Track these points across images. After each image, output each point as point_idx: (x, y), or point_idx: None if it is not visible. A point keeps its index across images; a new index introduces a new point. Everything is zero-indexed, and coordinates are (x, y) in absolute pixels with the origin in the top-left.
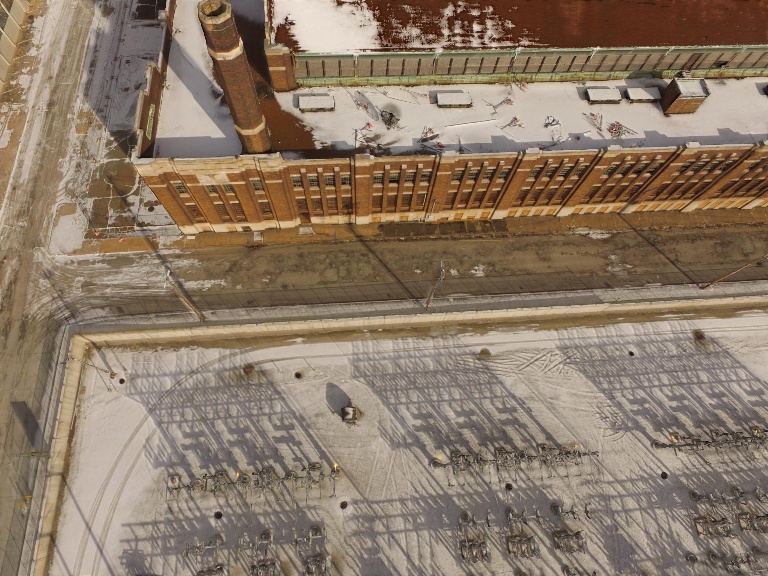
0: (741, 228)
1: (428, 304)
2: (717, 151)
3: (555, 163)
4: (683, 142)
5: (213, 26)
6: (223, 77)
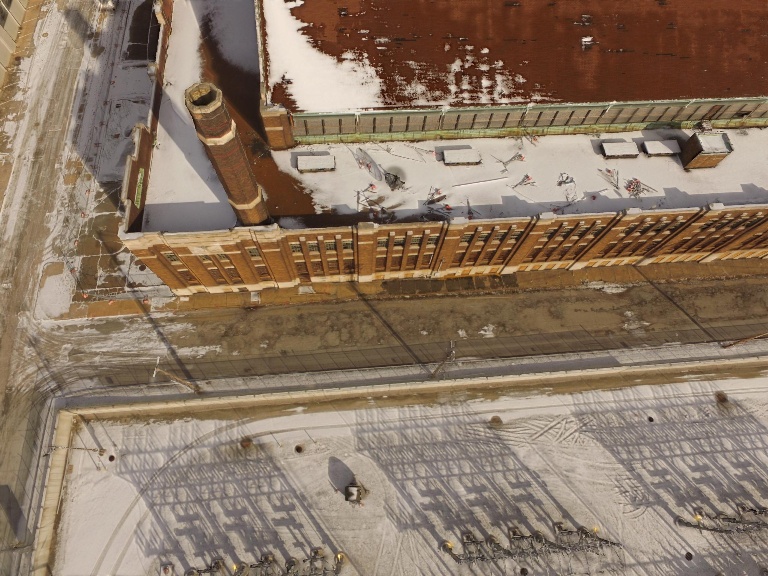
0: (763, 279)
1: (436, 372)
2: (742, 211)
3: (570, 225)
4: (705, 200)
5: (202, 115)
6: (214, 159)
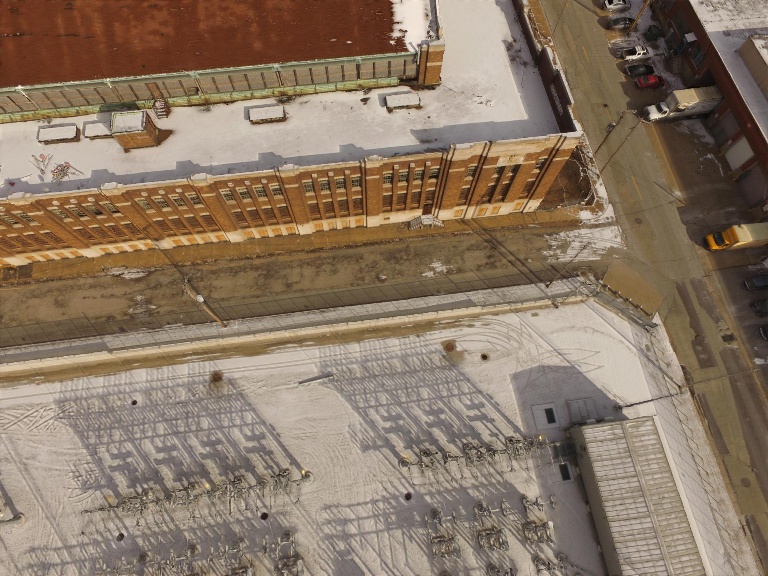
0: (296, 256)
1: None
2: (152, 189)
3: None
4: (130, 180)
5: None
6: None
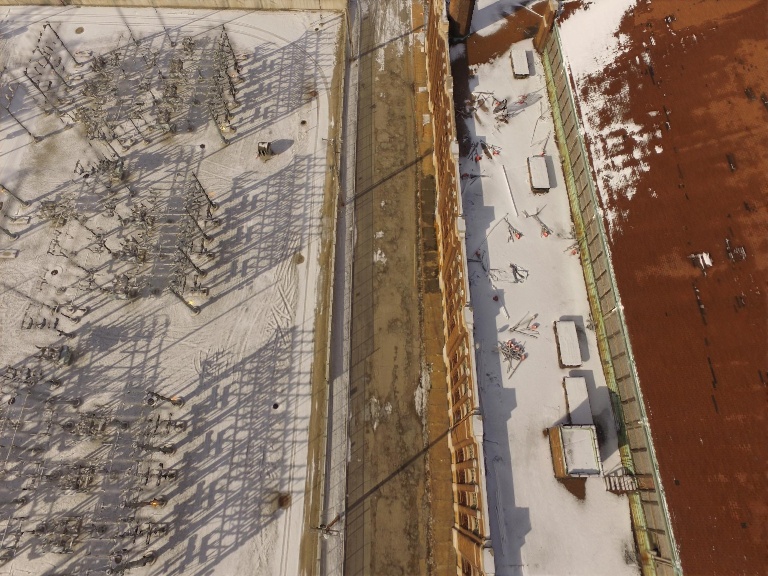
0: None
1: None
2: None
3: None
4: (499, 441)
5: None
6: None
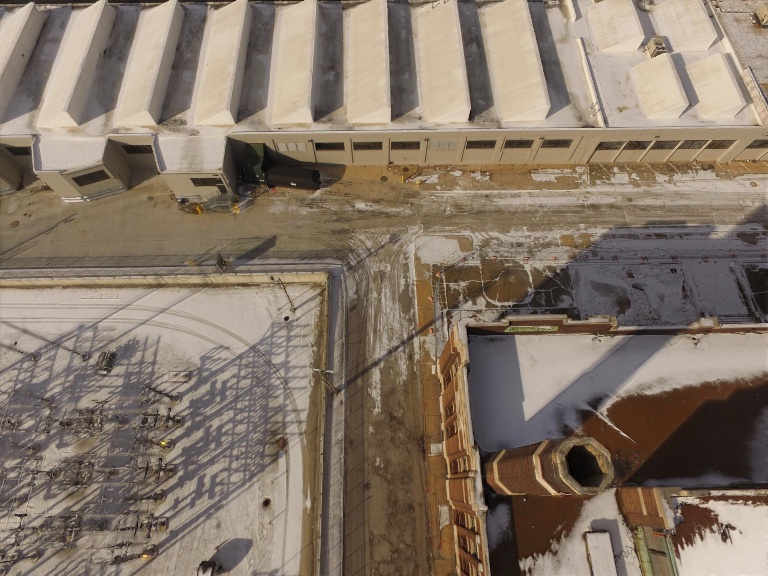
0: None
1: None
2: None
3: None
4: None
5: None
6: None
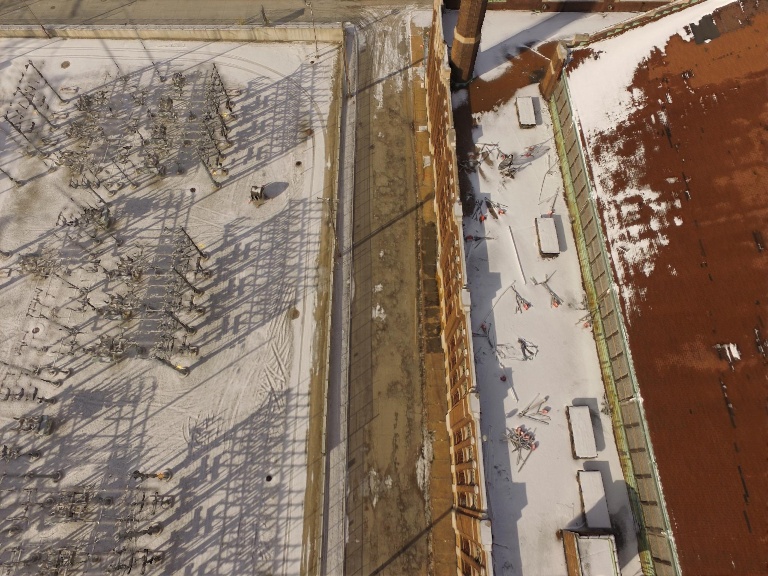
0: None
1: None
2: None
3: None
4: (509, 545)
5: None
6: None
